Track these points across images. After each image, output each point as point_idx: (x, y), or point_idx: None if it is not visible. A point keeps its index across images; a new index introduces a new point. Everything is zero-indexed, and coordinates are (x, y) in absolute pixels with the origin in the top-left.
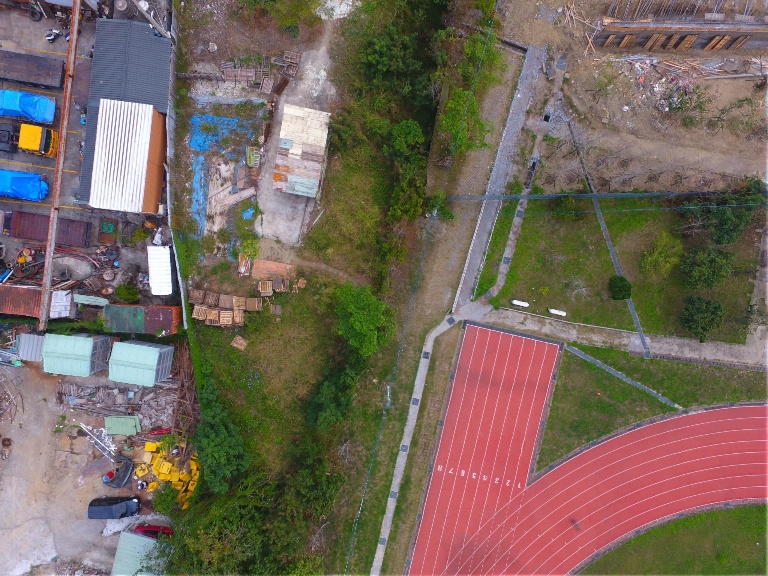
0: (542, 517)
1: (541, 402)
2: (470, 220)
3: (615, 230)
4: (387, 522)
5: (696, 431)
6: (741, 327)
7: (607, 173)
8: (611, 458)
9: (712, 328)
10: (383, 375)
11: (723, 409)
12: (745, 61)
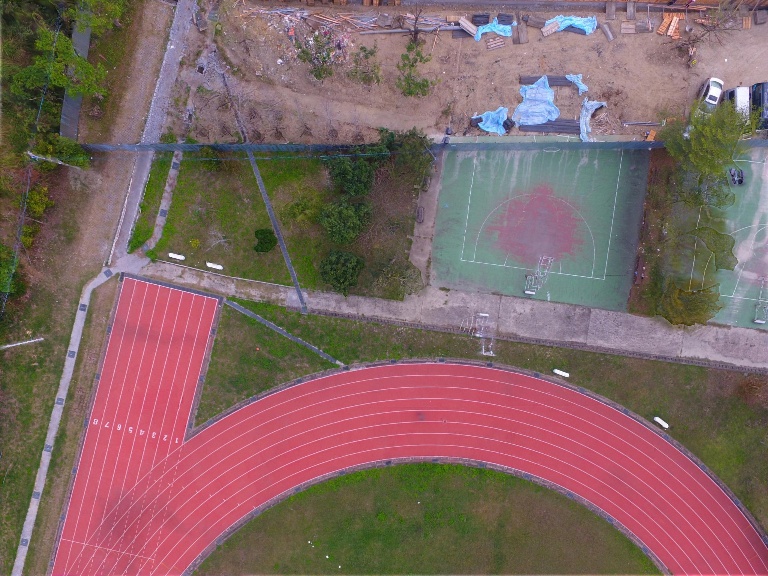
0: (200, 473)
1: (200, 357)
2: (125, 171)
3: (271, 184)
4: (41, 476)
5: (357, 388)
6: (376, 280)
7: (262, 126)
8: (271, 414)
9: (348, 281)
10: (36, 326)
11: (384, 366)
12: (399, 16)
